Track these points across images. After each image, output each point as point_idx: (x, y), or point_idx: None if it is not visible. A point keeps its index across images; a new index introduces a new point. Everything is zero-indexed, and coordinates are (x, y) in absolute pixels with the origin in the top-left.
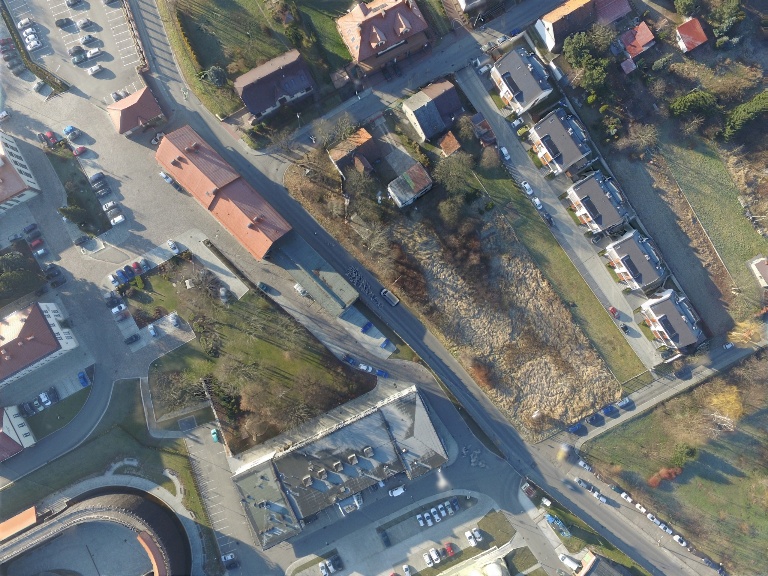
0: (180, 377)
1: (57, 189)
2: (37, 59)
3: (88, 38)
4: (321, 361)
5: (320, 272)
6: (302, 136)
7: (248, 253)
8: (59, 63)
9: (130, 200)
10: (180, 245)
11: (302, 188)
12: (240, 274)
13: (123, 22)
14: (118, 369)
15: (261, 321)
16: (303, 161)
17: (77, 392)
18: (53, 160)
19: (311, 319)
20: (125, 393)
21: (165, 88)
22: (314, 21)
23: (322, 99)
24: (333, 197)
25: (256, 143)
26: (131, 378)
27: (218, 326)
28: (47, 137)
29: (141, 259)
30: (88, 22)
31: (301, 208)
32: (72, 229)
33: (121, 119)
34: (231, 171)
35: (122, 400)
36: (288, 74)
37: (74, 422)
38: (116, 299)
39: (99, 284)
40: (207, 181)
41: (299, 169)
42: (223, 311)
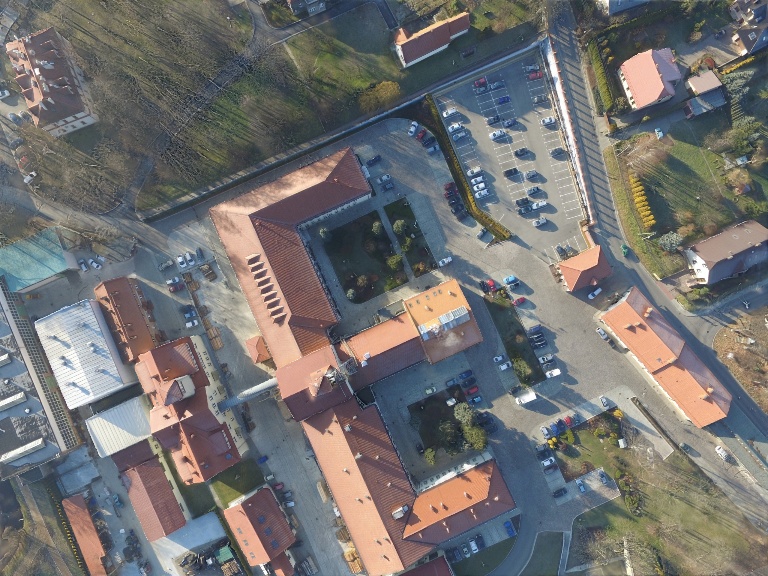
0: (604, 534)
1: (493, 336)
2: (483, 207)
3: (536, 190)
4: (739, 527)
5: (754, 442)
6: (735, 300)
7: (672, 413)
8: (504, 212)
9: (564, 353)
10: (609, 401)
11: (735, 354)
12: (665, 434)
13: (568, 175)
14: (542, 521)
15: (683, 483)
16: (737, 327)
17: (502, 541)
18: (491, 307)
19: (728, 483)
20: (548, 546)
21: (606, 244)
22: (765, 190)
23: (766, 268)
24: (767, 366)
25: (694, 306)
26: (555, 531)
27: (642, 485)
28: (488, 285)
29: (574, 414)
30: (536, 174)
31: (727, 372)
32: (505, 378)
33: (578, 279)
34: (678, 337)
35: (545, 552)
36: (756, 250)
37: (497, 570)
38: (547, 452)
39: (529, 434)
40: (664, 349)
41: (732, 334)
42: (648, 471)
